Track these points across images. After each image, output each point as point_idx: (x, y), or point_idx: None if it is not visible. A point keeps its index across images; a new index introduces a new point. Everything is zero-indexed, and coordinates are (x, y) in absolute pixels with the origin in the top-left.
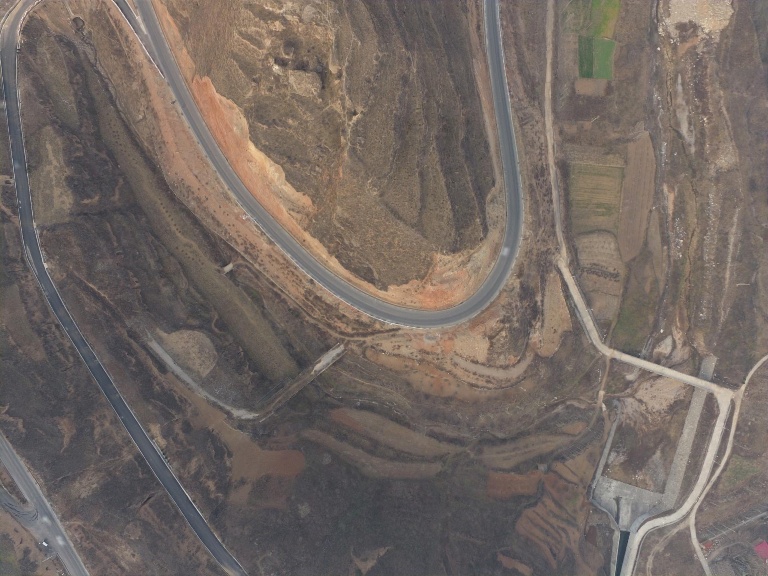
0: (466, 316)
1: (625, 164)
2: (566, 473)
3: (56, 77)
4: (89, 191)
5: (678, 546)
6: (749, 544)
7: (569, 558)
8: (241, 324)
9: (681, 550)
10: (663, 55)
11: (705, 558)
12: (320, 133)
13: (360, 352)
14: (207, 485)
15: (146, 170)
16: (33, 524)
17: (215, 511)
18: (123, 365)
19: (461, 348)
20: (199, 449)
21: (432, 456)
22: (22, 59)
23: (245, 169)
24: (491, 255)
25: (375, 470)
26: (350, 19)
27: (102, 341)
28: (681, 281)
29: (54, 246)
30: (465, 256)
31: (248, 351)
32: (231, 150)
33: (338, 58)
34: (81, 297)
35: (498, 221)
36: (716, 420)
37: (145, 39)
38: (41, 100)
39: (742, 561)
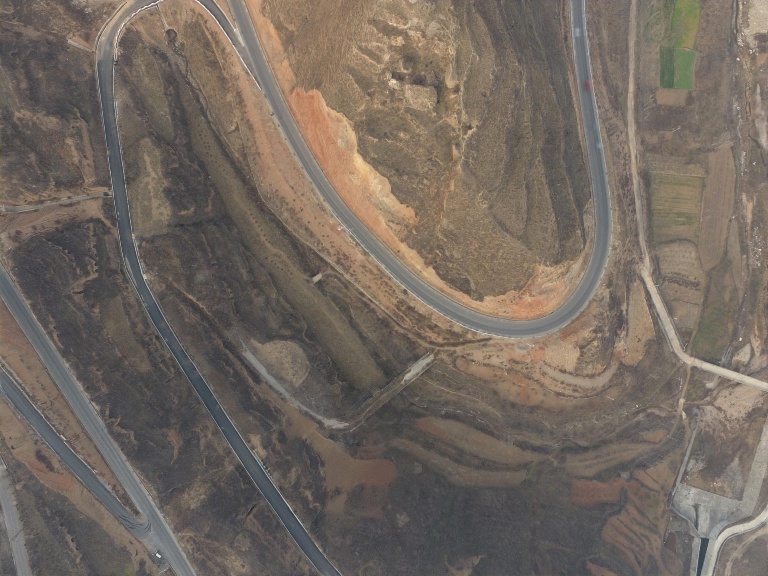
0: (556, 326)
1: (706, 174)
2: (647, 481)
3: (151, 89)
4: (185, 202)
5: (756, 553)
6: None
7: (653, 565)
8: (329, 334)
9: (759, 557)
10: (742, 65)
11: None
12: (432, 146)
13: (450, 362)
14: (306, 495)
15: (236, 181)
16: (146, 536)
17: (315, 521)
18: (223, 376)
19: (551, 357)
20: (296, 459)
21: (516, 464)
22: (119, 71)
23: (344, 181)
24: (581, 265)
25: (461, 479)
26: (470, 34)
27: (202, 352)
28: (759, 290)
29: (153, 257)
30: (565, 267)
31: (336, 361)
32: (329, 162)
33: (457, 73)
34: (181, 308)
35: (589, 231)
36: None
37: (243, 51)
38: (138, 112)
39: None
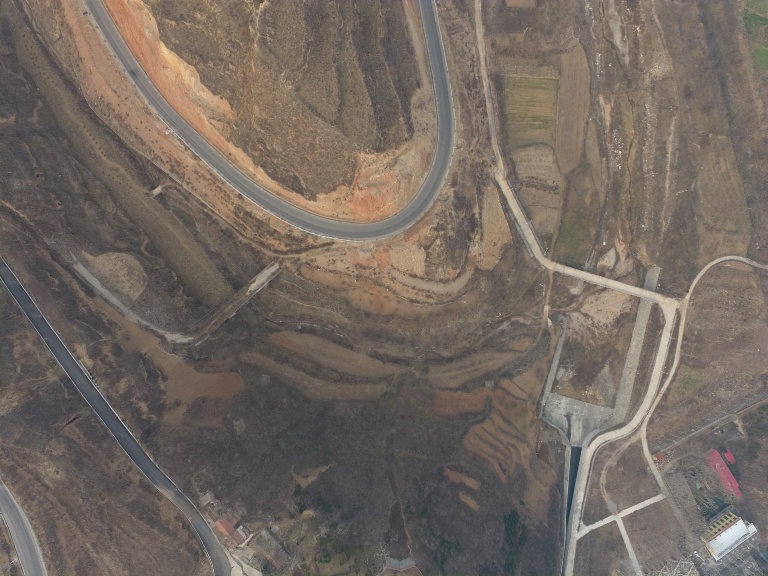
0: (401, 227)
1: (559, 75)
2: (514, 390)
3: None
4: (4, 110)
5: (631, 460)
6: (701, 454)
7: (519, 473)
8: (173, 248)
9: (634, 464)
10: None
11: (658, 471)
12: (229, 26)
13: (295, 269)
14: (138, 406)
15: (67, 92)
16: None
17: (147, 431)
18: (44, 285)
19: (397, 261)
20: (129, 370)
21: (377, 377)
22: None
23: (163, 79)
24: (423, 165)
25: (318, 392)
26: None
27: (22, 261)
28: (621, 193)
29: None
30: (391, 157)
31: (182, 276)
32: (148, 61)
33: None
34: None
35: (428, 129)
36: (662, 330)
37: None
38: None
39: (695, 472)
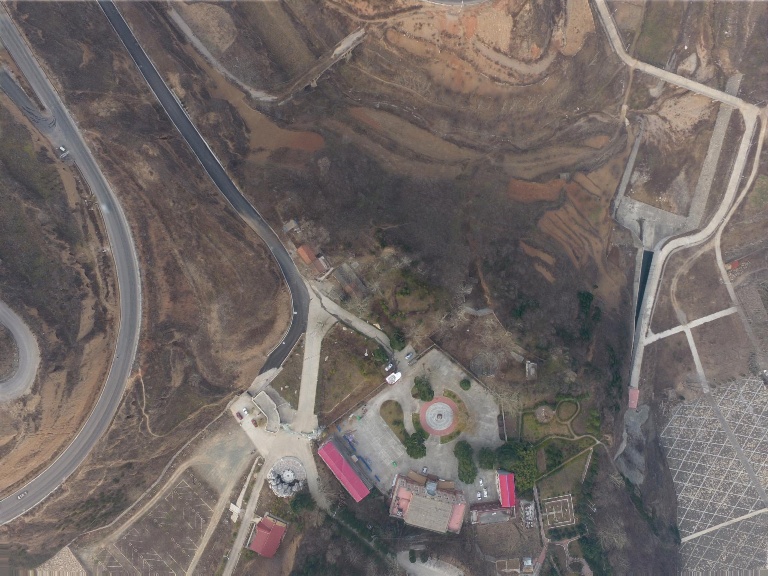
0: None
1: None
2: (588, 185)
3: None
4: None
5: (703, 269)
6: None
7: (592, 263)
8: (260, 15)
9: (706, 273)
10: None
11: (731, 282)
12: None
13: (381, 34)
14: (225, 141)
15: None
16: (50, 131)
17: (233, 162)
18: (143, 14)
19: (484, 30)
20: (218, 109)
21: (452, 161)
22: None
23: None
24: None
25: (394, 167)
26: None
27: None
28: None
29: None
30: None
31: (267, 43)
32: None
33: None
34: None
35: None
36: (742, 137)
37: None
38: None
39: None
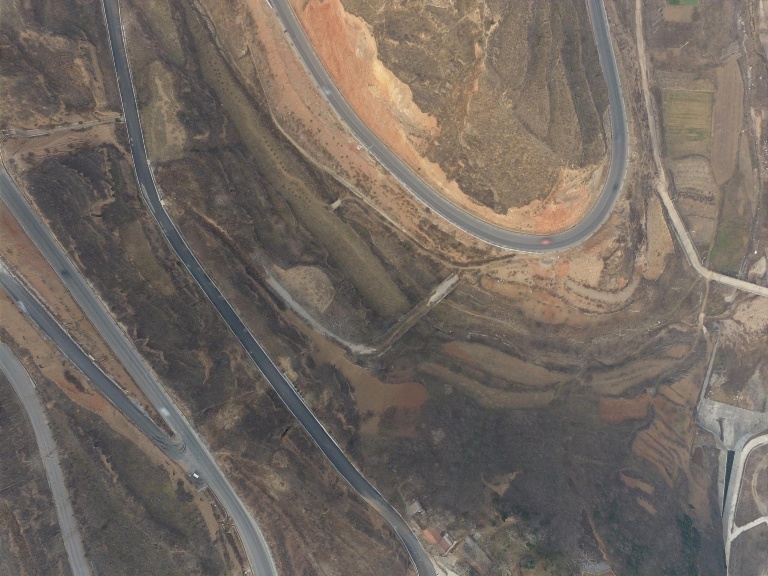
0: (579, 239)
1: (715, 88)
2: (673, 396)
3: (158, 13)
4: (200, 127)
5: None
6: None
7: (683, 477)
8: (351, 261)
9: None
10: None
11: None
12: (454, 46)
13: (475, 281)
14: (339, 417)
15: (249, 108)
16: (181, 457)
17: (350, 442)
18: (249, 299)
19: (575, 272)
20: (327, 382)
21: (543, 385)
22: None
23: (362, 96)
24: (600, 178)
25: (491, 401)
26: None
27: (226, 276)
28: None
29: (171, 182)
30: (588, 172)
31: (359, 288)
32: (346, 78)
33: None
34: (202, 233)
35: None
36: None
37: None
38: (147, 35)
39: None
